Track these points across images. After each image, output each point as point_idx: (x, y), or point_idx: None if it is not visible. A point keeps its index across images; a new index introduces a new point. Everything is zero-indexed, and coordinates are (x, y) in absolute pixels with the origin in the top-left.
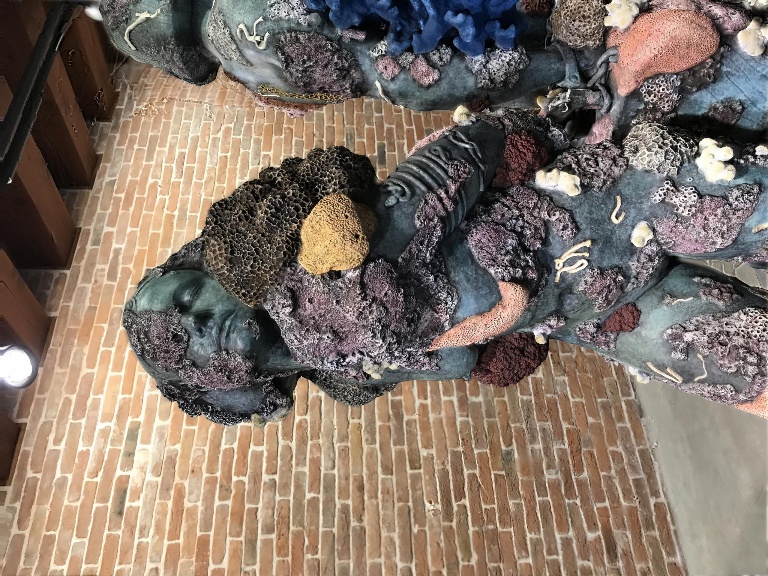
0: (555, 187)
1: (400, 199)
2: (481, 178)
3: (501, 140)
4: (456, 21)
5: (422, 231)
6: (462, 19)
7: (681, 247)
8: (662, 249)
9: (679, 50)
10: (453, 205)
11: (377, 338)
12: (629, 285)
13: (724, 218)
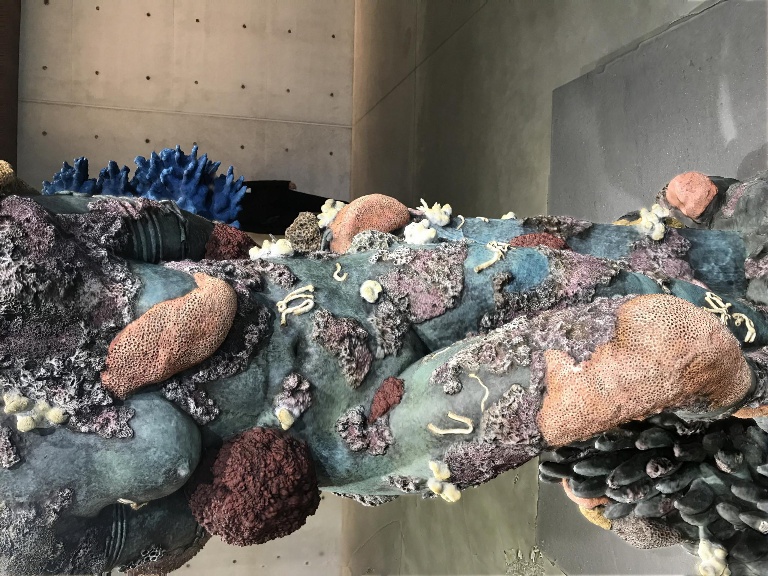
0: (269, 255)
1: (74, 193)
2: (182, 229)
3: (209, 226)
4: (178, 202)
5: (96, 214)
6: (182, 199)
7: (419, 306)
8: (402, 314)
9: (375, 210)
10: (139, 215)
11: (5, 257)
12: (378, 349)
13: (442, 261)
